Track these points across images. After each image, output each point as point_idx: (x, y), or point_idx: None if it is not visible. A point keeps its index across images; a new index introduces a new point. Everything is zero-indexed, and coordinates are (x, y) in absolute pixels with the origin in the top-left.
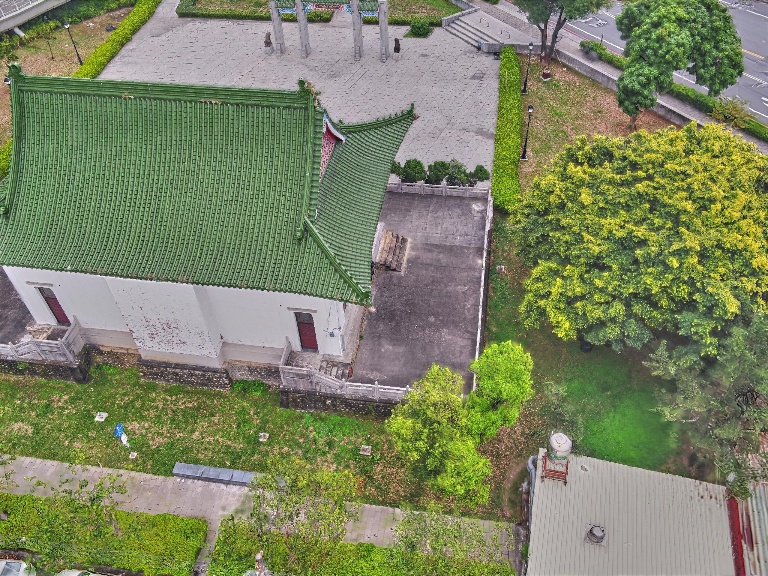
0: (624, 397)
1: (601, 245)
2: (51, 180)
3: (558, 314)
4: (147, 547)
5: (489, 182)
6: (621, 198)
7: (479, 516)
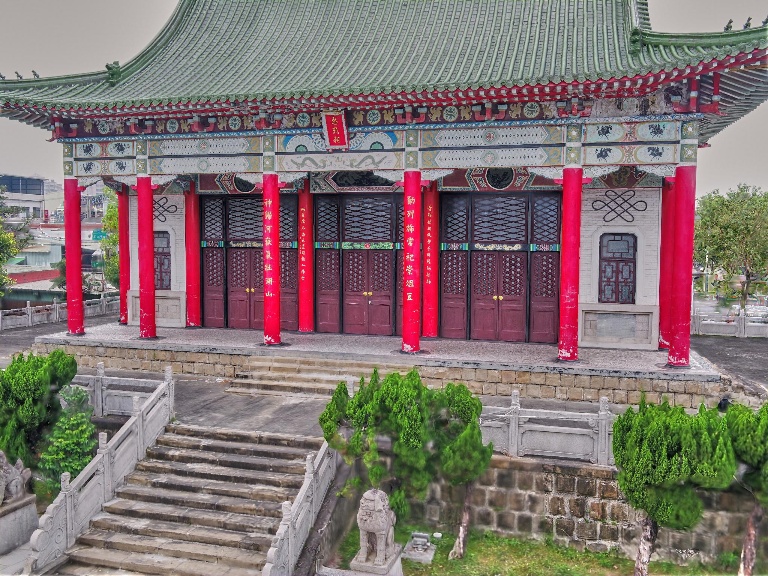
0: None
1: None
2: None
3: None
4: None
5: None
6: None
7: None
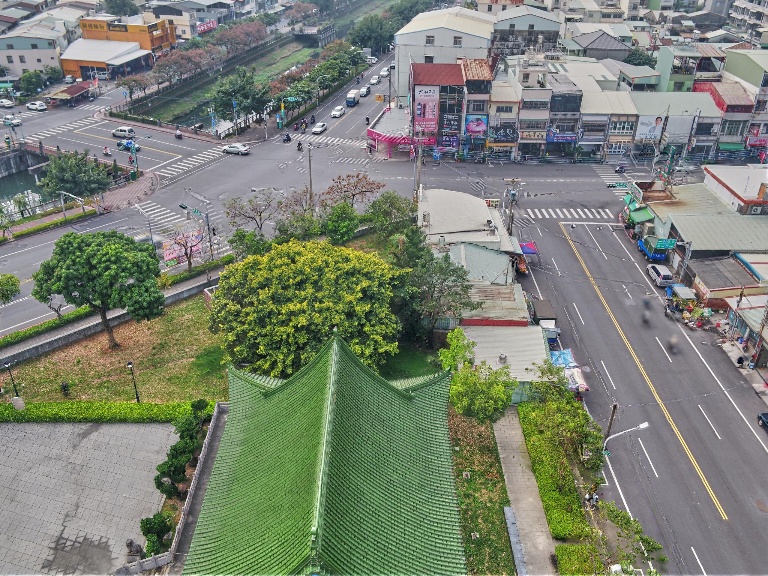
0: (394, 367)
1: (362, 306)
2: (387, 569)
3: (388, 346)
4: (589, 574)
5: (172, 426)
6: (331, 289)
7: (490, 422)
